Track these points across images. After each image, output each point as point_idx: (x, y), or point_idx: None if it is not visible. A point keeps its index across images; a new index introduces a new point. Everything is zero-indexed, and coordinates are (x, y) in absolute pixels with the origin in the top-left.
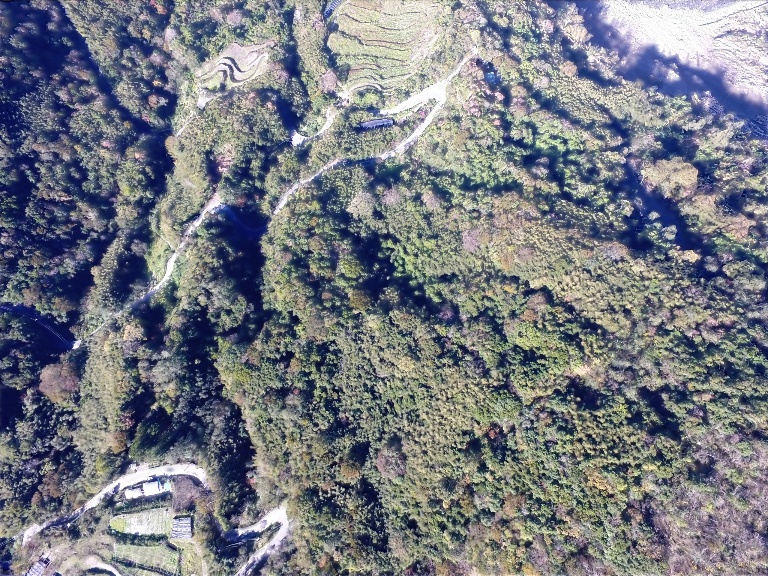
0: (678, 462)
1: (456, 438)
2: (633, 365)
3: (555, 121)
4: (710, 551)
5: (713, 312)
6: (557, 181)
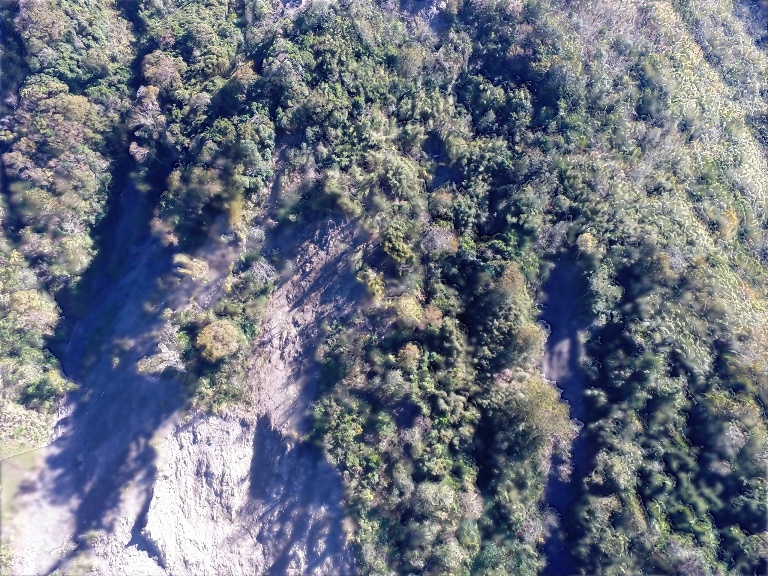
0: (651, 50)
1: (751, 147)
2: (665, 132)
3: (715, 569)
4: (634, 5)
5: (601, 155)
6: (688, 436)
